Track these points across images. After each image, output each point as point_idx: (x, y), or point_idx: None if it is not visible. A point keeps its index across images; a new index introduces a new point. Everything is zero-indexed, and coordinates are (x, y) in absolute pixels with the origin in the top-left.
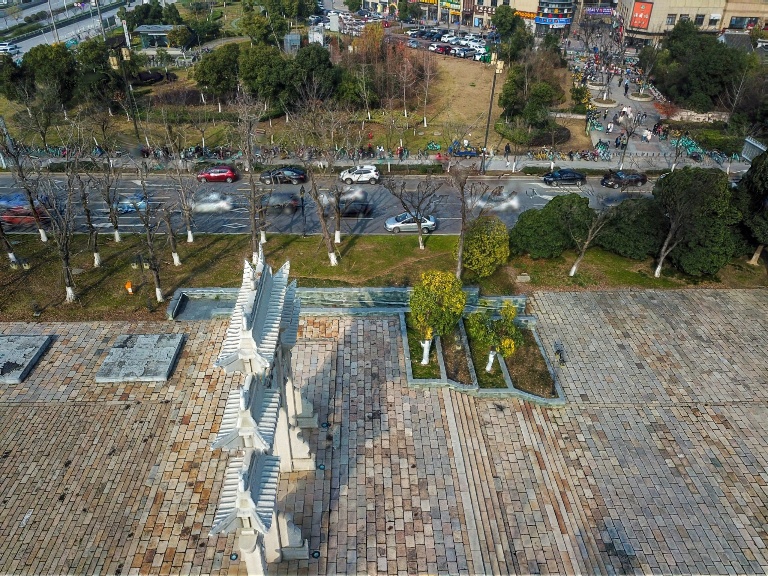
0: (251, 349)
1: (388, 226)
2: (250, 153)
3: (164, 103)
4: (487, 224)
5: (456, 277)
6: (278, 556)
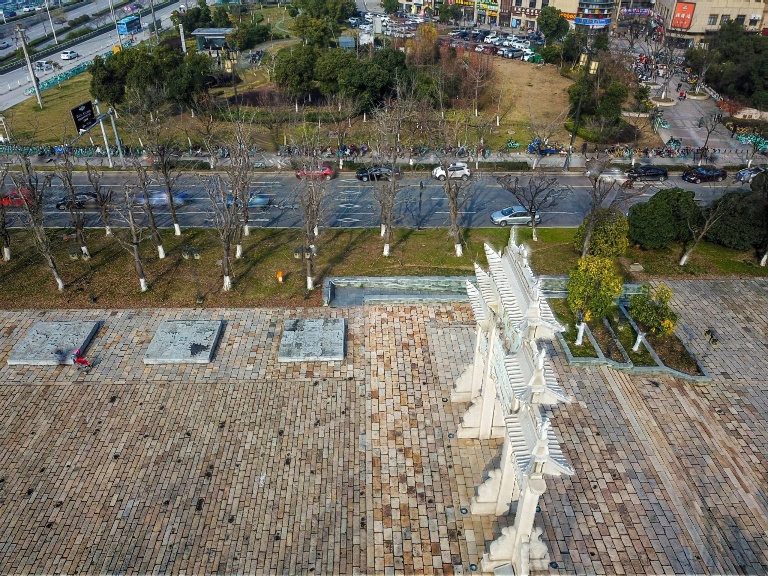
0: (536, 317)
1: (495, 220)
2: (396, 150)
3: (268, 104)
4: (609, 216)
5: None
6: (507, 509)
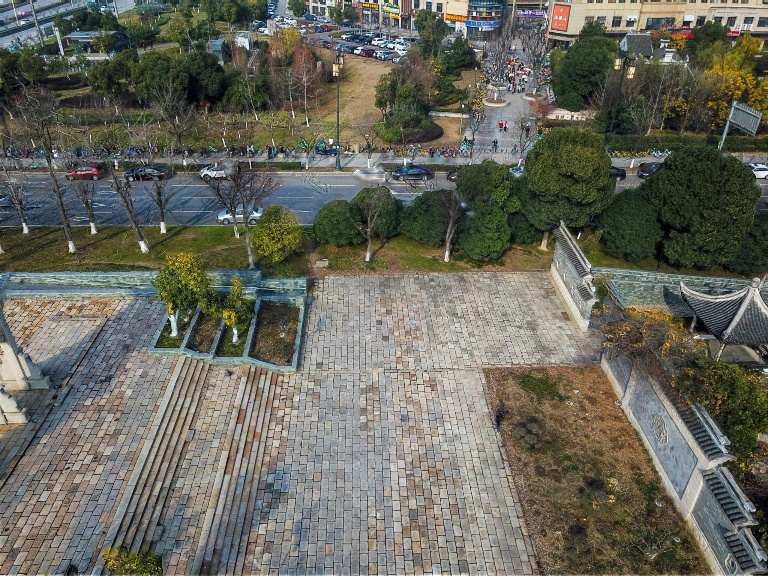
0: None
1: (218, 218)
2: (45, 150)
3: None
4: (276, 213)
5: (249, 262)
6: None
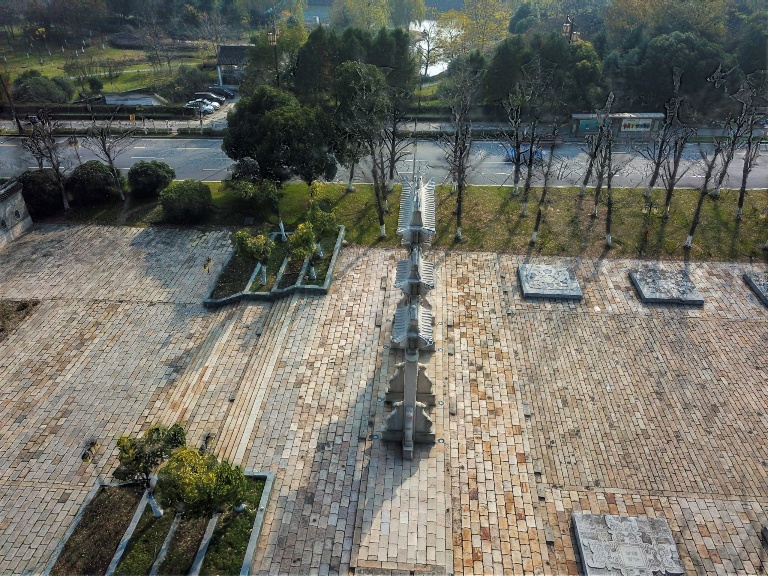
0: None
1: None
2: None
3: None
4: None
5: None
6: None
